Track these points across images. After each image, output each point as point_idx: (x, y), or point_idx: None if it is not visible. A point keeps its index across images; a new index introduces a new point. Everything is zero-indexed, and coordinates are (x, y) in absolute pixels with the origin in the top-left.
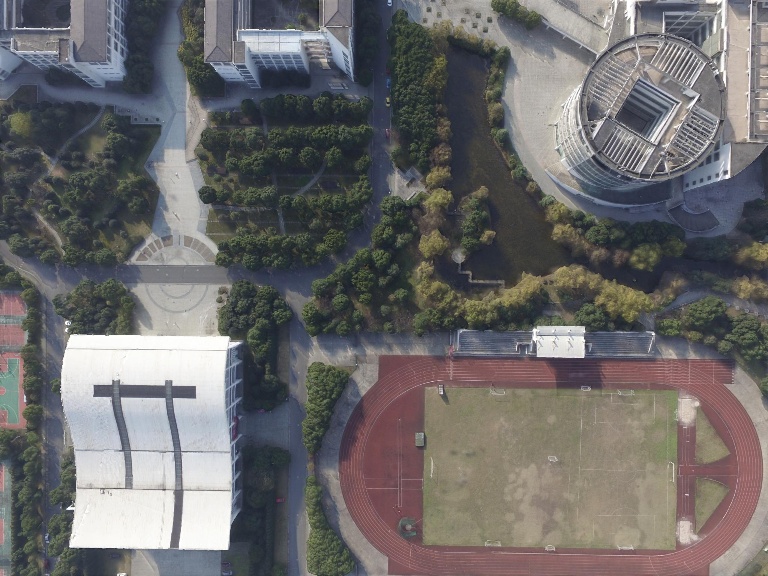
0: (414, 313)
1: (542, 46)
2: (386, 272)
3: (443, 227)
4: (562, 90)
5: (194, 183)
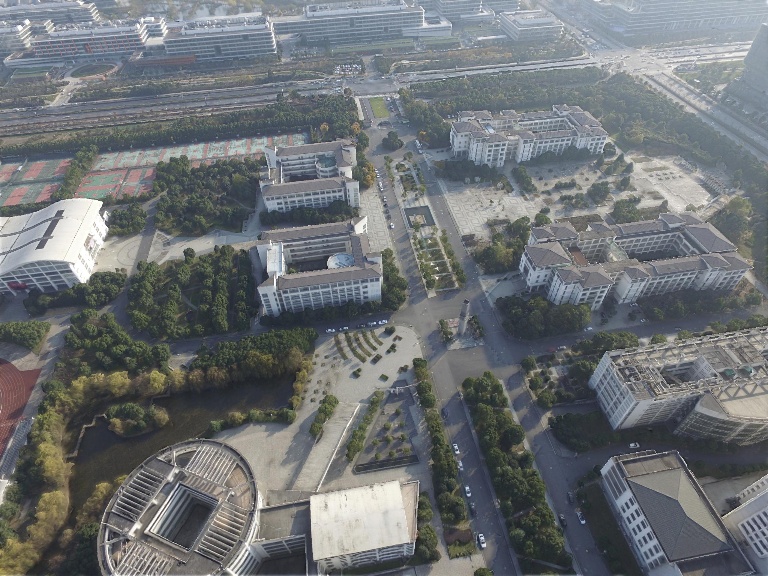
0: (68, 385)
1: (301, 450)
2: None
3: (142, 398)
4: (258, 476)
5: (203, 251)
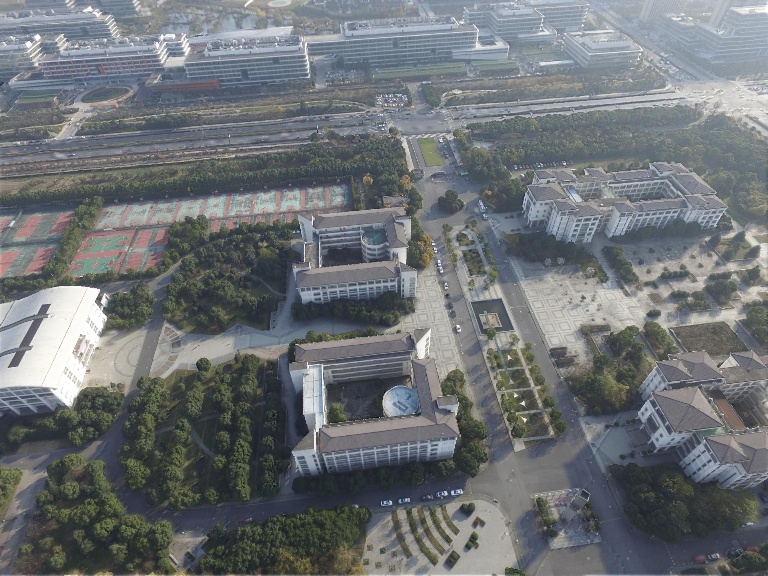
0: None
1: None
2: (88, 537)
3: None
4: None
5: (220, 357)
